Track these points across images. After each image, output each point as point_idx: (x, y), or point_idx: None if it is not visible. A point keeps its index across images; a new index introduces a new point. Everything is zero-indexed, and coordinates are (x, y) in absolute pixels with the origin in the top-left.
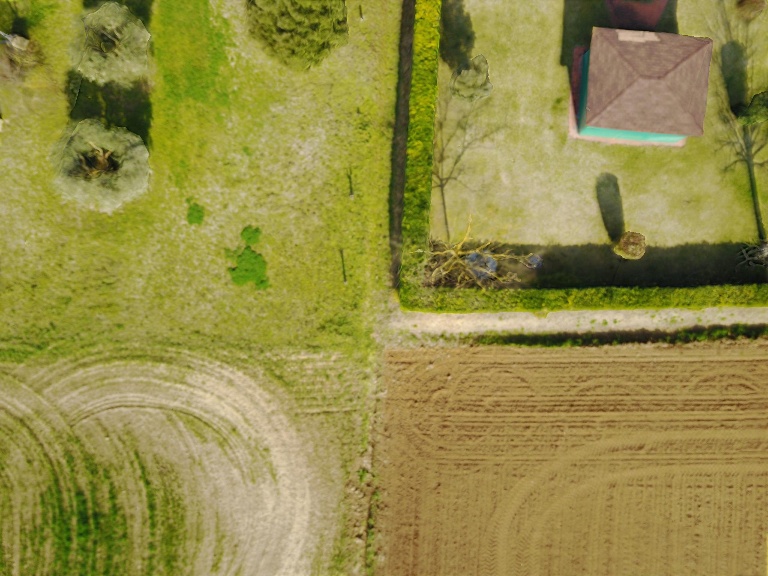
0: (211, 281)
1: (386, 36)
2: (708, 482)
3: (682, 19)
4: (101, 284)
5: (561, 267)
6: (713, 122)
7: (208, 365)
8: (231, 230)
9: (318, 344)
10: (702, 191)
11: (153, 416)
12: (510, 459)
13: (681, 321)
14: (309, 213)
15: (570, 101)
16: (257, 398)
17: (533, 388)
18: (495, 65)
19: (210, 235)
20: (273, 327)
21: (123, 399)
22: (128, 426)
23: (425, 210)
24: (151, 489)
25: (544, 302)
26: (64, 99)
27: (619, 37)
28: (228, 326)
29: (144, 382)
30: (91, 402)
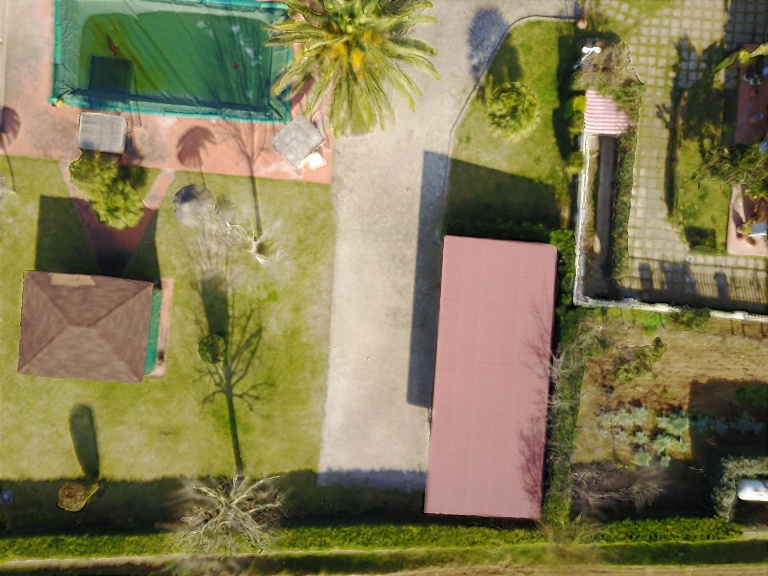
0: None
1: None
2: None
3: (161, 245)
4: None
5: (33, 503)
6: (193, 351)
7: None
8: None
9: None
10: (180, 423)
11: None
12: None
13: (165, 556)
14: None
15: None
16: None
17: None
18: None
19: None
20: None
21: None
22: None
23: None
24: None
25: None
26: None
27: (51, 281)
28: None
29: None
30: None
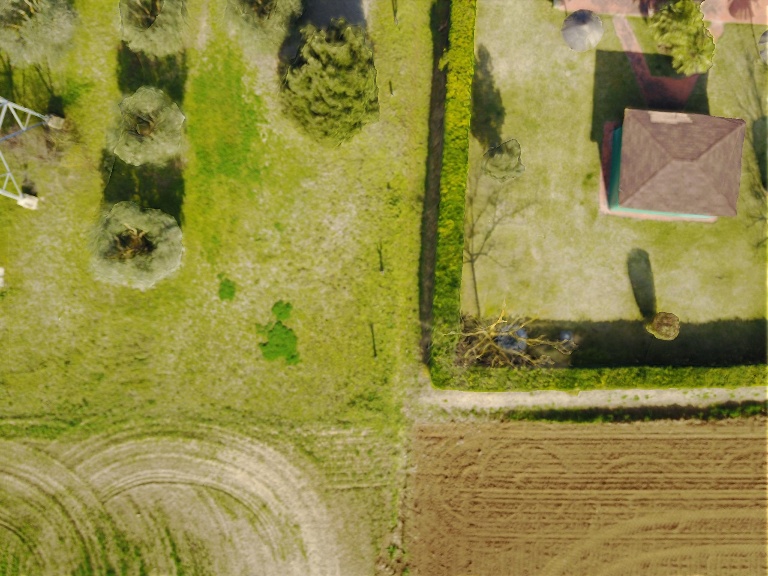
0: (242, 356)
1: (416, 111)
2: (744, 562)
3: (712, 95)
4: (133, 360)
5: (592, 343)
6: (745, 198)
7: (239, 441)
8: (262, 305)
9: (348, 419)
10: (734, 267)
11: (184, 492)
12: (542, 537)
13: (714, 397)
14: (339, 288)
15: (600, 177)
16: (287, 474)
17: (565, 465)
18: (525, 141)
19: (241, 310)
20: (303, 402)
21: (154, 475)
22: (159, 502)
23: (457, 289)
24: (182, 566)
25: (577, 382)
26: (98, 176)
27: (651, 119)
28: (259, 401)
29: (175, 458)
30: (123, 478)
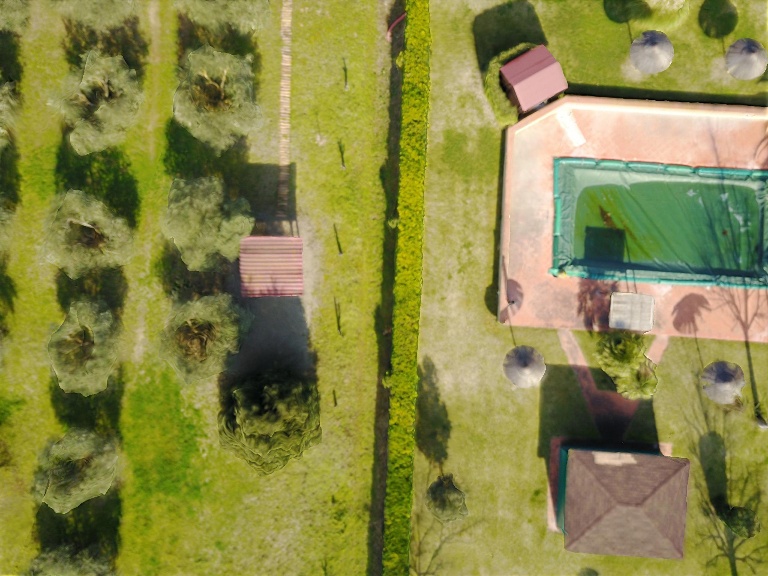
0: None
1: (361, 416)
2: None
3: (658, 409)
4: None
5: None
6: (693, 514)
7: None
8: None
9: None
10: None
11: None
12: None
13: None
14: None
15: (548, 493)
16: None
17: None
18: (471, 456)
19: None
20: None
21: None
22: None
23: None
24: None
25: None
26: (30, 500)
27: (595, 460)
28: None
29: None
30: None
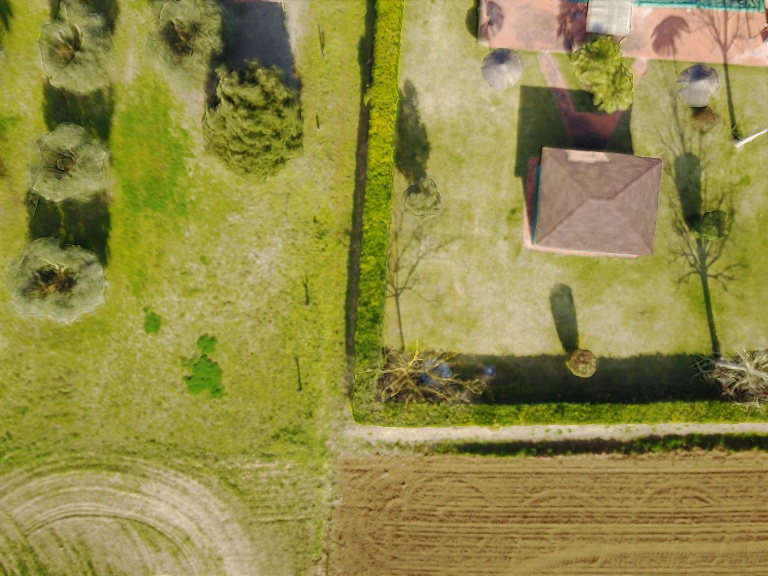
0: (167, 389)
1: (343, 144)
2: None
3: (635, 131)
4: (58, 393)
5: (515, 377)
6: (667, 234)
7: (163, 474)
8: (187, 338)
9: (273, 452)
10: (656, 303)
11: (108, 525)
12: (464, 570)
13: (636, 431)
14: (265, 321)
15: (524, 212)
16: (212, 507)
17: (487, 498)
18: (450, 176)
19: (166, 344)
20: (228, 435)
21: (78, 508)
22: (83, 535)
23: (377, 325)
24: None
25: (495, 418)
26: (23, 209)
27: (568, 158)
28: (183, 434)
29: (99, 491)
30: (46, 511)
